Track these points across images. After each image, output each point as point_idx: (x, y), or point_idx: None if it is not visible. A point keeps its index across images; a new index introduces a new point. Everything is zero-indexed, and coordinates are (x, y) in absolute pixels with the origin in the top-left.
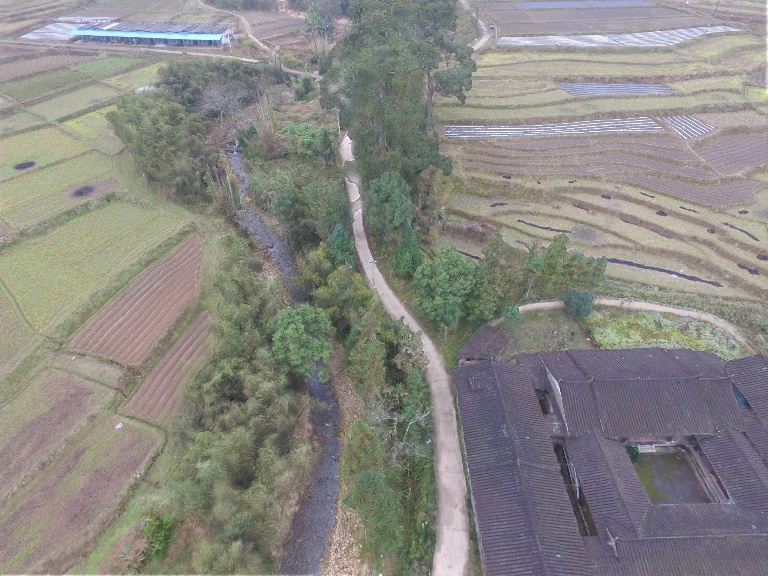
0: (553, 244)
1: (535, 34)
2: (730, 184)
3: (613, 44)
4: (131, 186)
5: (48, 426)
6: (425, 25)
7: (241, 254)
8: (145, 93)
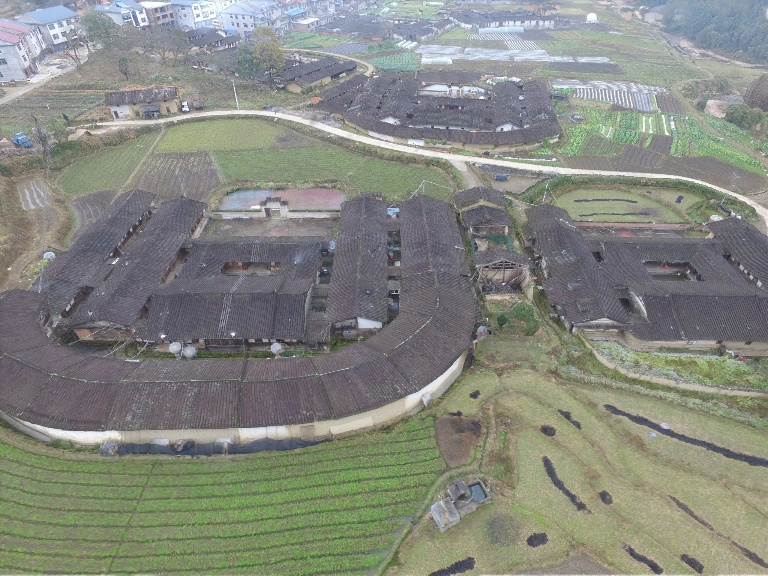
0: None
1: None
2: None
3: None
4: None
5: None
6: None
7: None
8: None
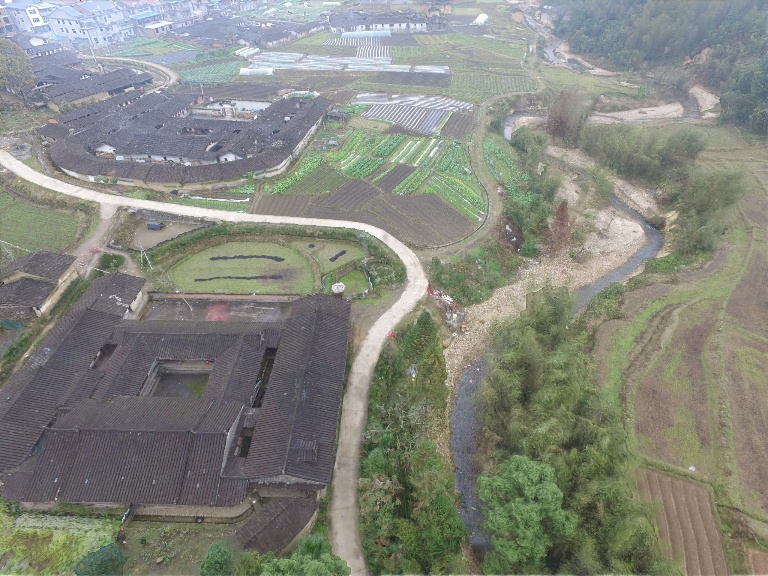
0: None
1: None
2: None
3: None
4: None
5: (766, 466)
6: None
7: None
8: None
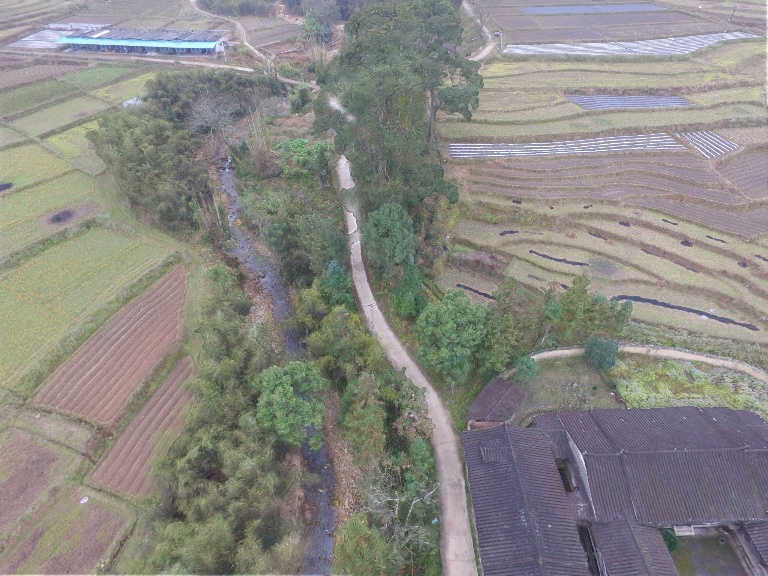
0: (573, 288)
1: (542, 42)
2: (759, 209)
3: (625, 52)
4: (113, 211)
5: (4, 501)
6: (428, 39)
7: (229, 289)
8: (129, 110)
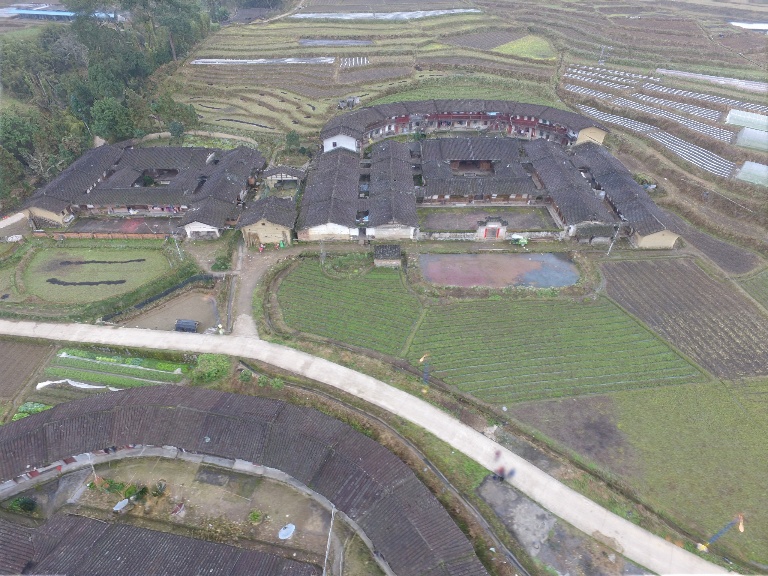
0: None
1: (322, 12)
2: None
3: None
4: None
5: None
6: None
7: None
8: (13, 37)
